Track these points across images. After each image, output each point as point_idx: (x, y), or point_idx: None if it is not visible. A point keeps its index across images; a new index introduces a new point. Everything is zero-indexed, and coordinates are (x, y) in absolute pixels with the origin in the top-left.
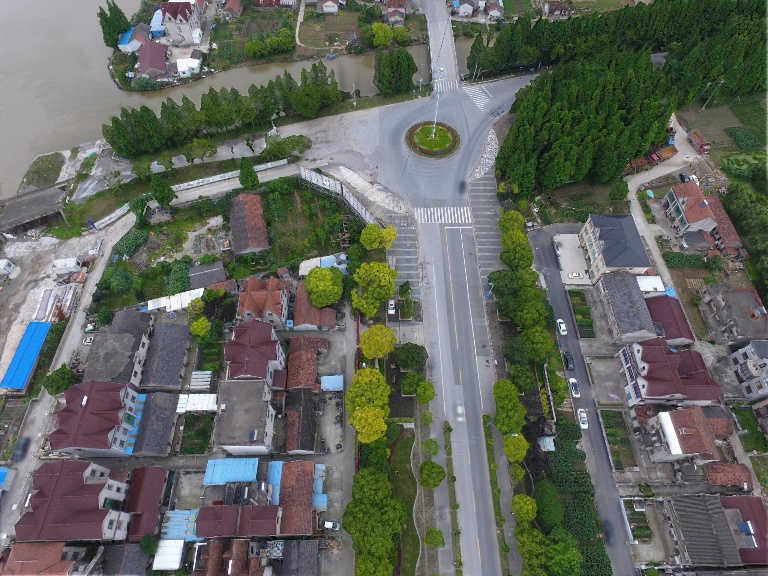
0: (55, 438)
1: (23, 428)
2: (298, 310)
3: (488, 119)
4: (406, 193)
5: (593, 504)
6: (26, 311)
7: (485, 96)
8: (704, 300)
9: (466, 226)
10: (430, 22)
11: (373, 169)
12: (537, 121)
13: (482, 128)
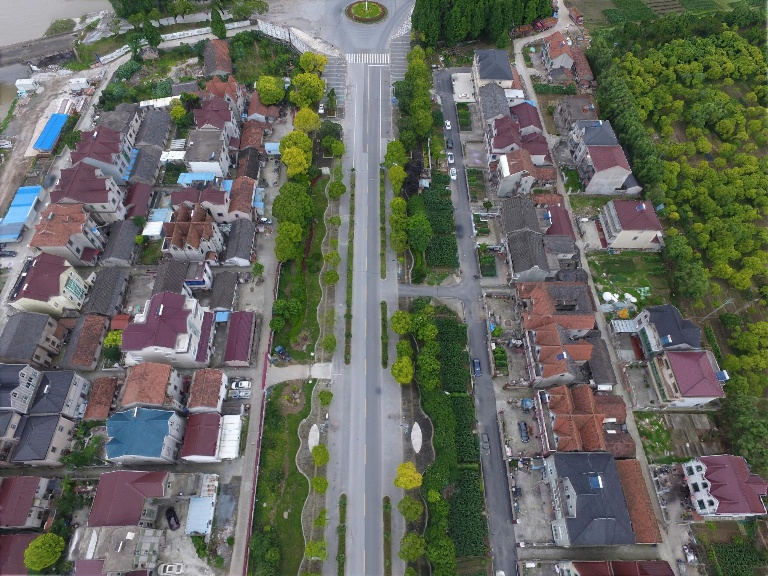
0: (75, 155)
1: (50, 171)
2: (251, 107)
3: (413, 1)
4: (341, 45)
5: (452, 218)
6: (49, 111)
7: None
8: (558, 111)
9: (385, 65)
10: None
11: (317, 30)
12: None
13: (407, 6)
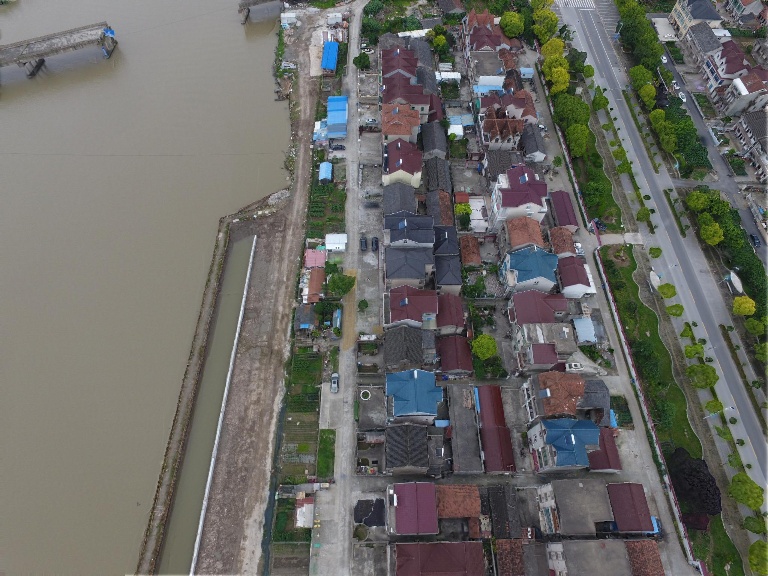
0: (386, 67)
1: (343, 86)
2: None
3: None
4: None
5: None
6: (315, 41)
7: None
8: (755, 50)
9: (592, 9)
10: None
11: None
12: None
13: None
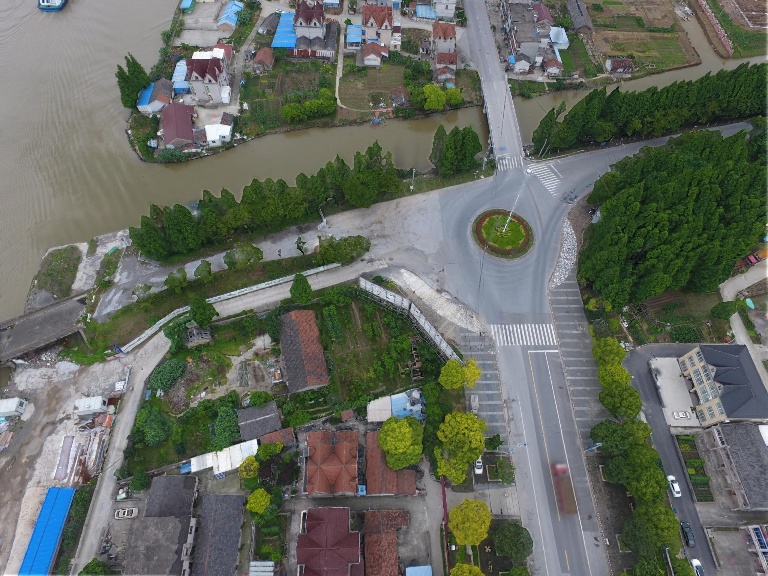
0: None
1: None
2: (371, 472)
3: (561, 206)
4: (479, 305)
5: None
6: (43, 467)
7: (554, 176)
8: None
9: (552, 349)
10: (484, 81)
11: (439, 273)
12: (631, 227)
13: (556, 218)
